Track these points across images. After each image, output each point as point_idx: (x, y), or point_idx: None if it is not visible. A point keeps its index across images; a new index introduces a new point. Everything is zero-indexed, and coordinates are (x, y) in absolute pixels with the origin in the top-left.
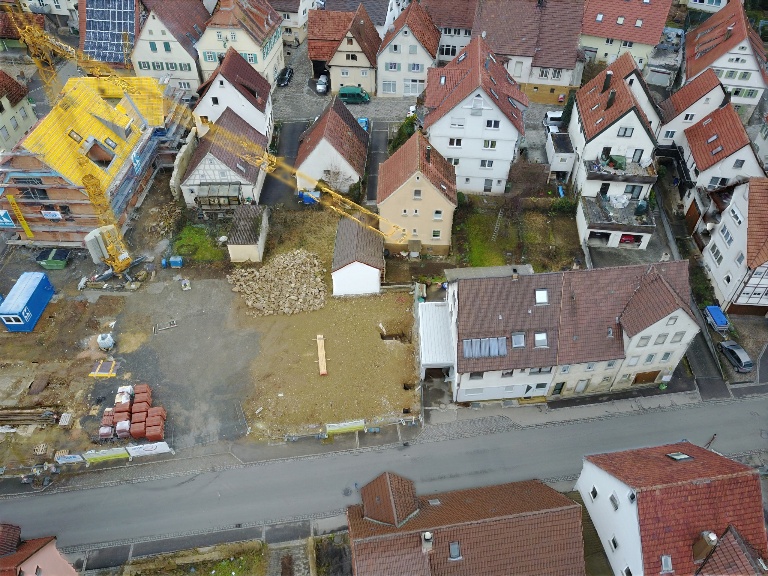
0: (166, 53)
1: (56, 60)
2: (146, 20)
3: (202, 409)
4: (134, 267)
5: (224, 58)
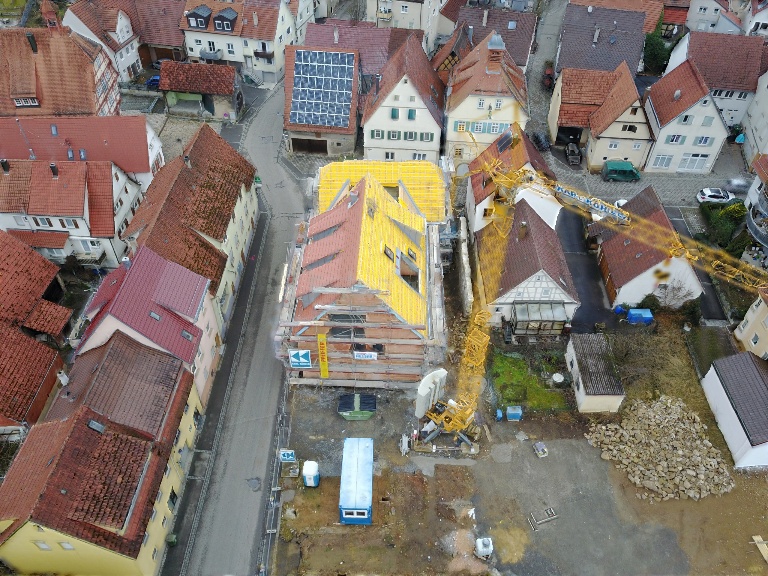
0: (408, 121)
1: (240, 117)
2: (396, 84)
3: None
4: None
5: (521, 139)
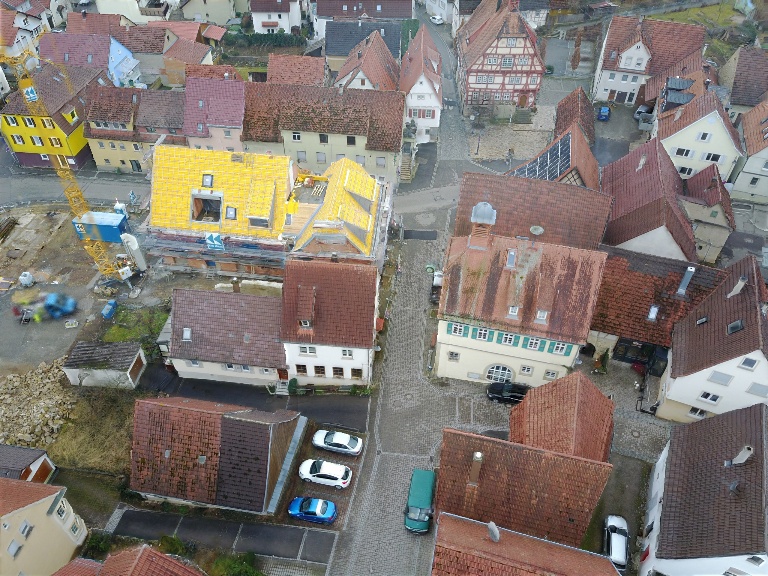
0: None
1: None
2: None
3: None
4: None
5: (332, 261)
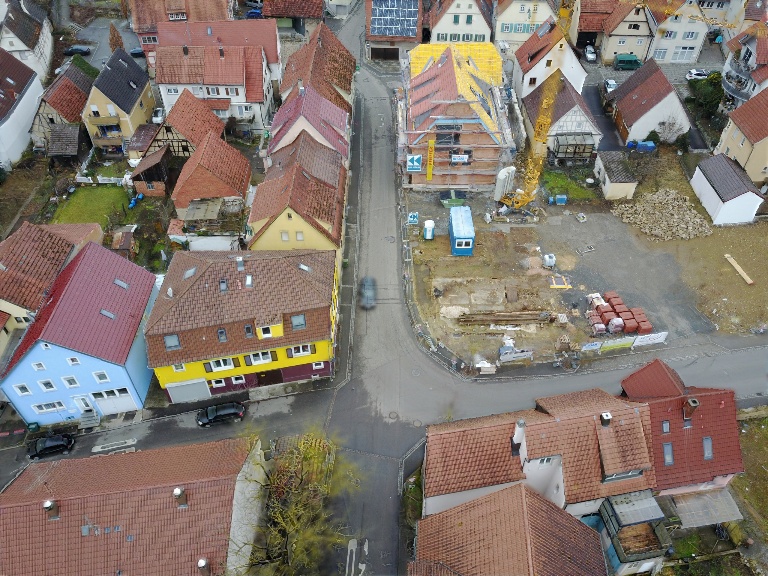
0: (466, 25)
1: None
2: None
3: (665, 311)
4: (522, 205)
5: (556, 25)
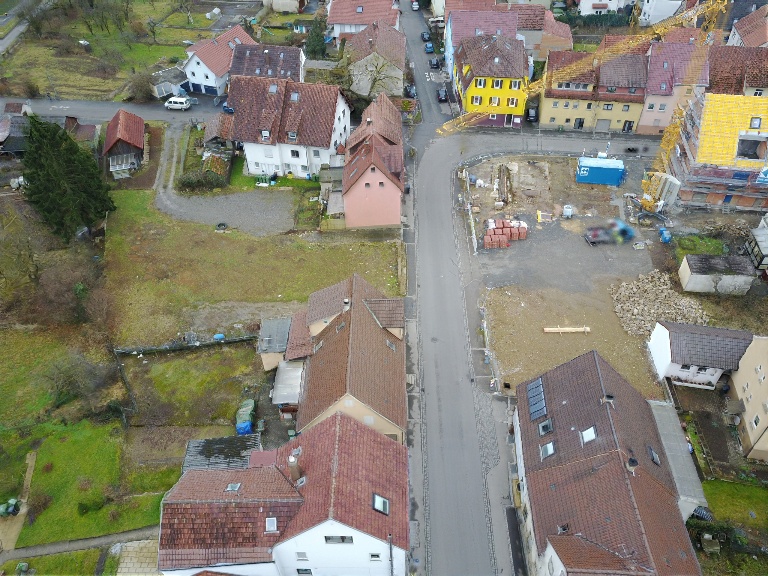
0: None
1: None
2: None
3: (510, 264)
4: (657, 218)
5: None
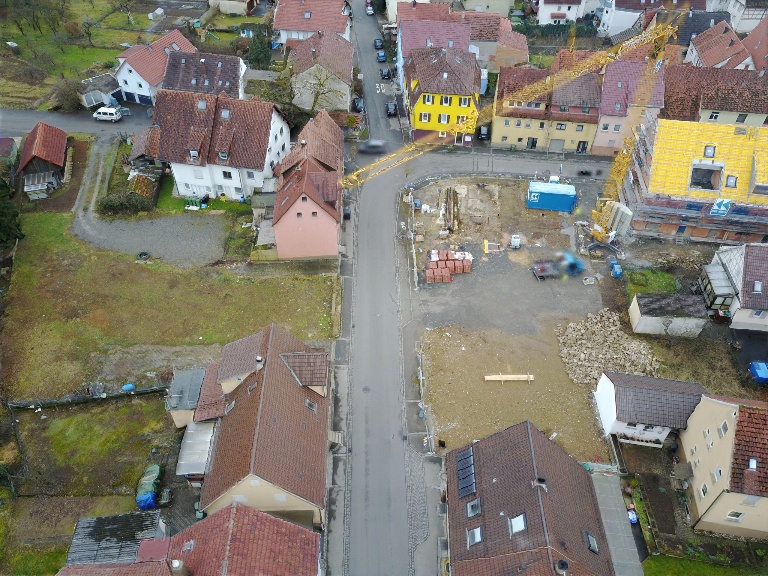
0: None
1: None
2: None
3: (452, 301)
4: (608, 249)
5: None
